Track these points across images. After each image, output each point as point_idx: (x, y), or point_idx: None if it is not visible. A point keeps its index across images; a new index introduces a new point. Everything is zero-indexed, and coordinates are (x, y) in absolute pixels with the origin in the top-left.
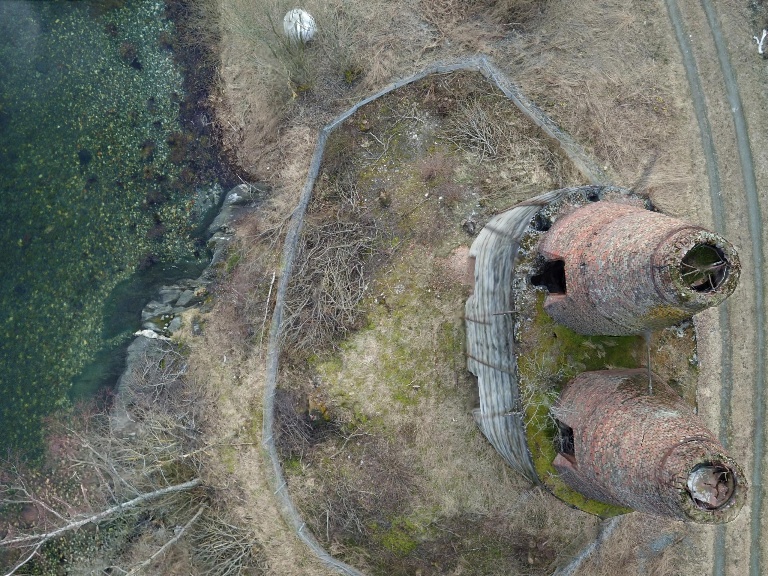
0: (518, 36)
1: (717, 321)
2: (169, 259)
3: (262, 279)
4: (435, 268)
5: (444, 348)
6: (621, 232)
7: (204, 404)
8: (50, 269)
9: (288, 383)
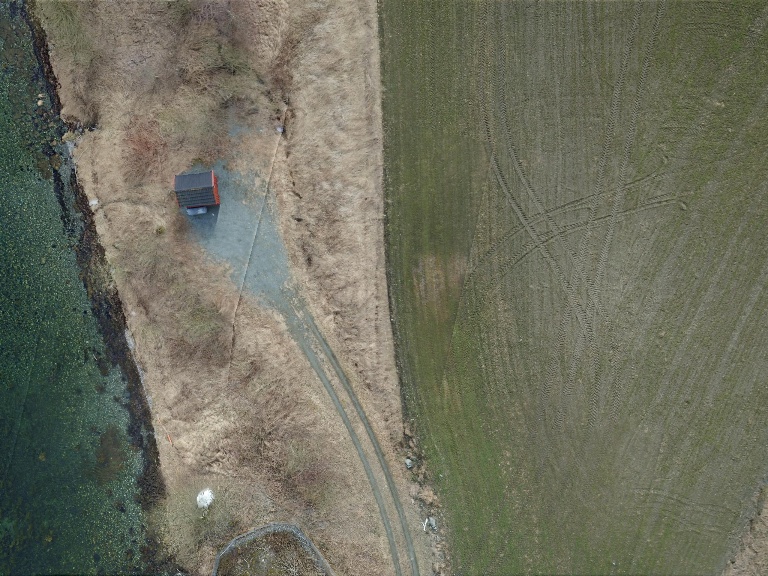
0: (313, 510)
1: None
2: None
3: None
4: None
5: None
6: None
7: None
8: None
9: None
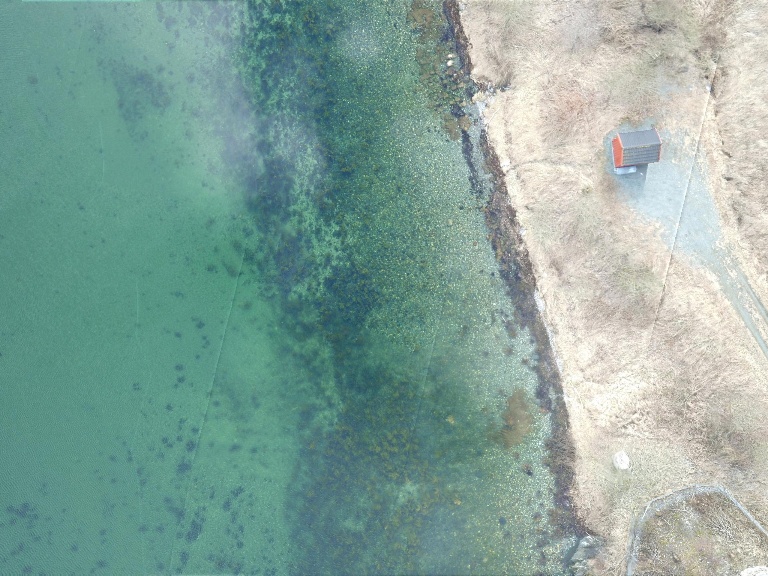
0: (739, 471)
1: None
2: (549, 574)
3: None
4: None
5: None
6: None
7: None
8: None
9: None
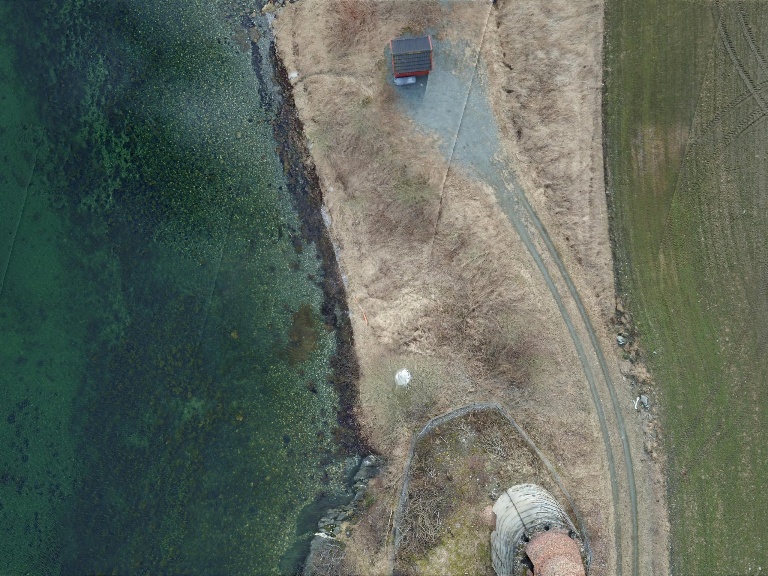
0: (516, 389)
1: (615, 543)
2: (332, 494)
3: (386, 513)
4: (476, 516)
5: (480, 555)
6: (552, 569)
7: (355, 575)
8: (268, 499)
9: (400, 567)
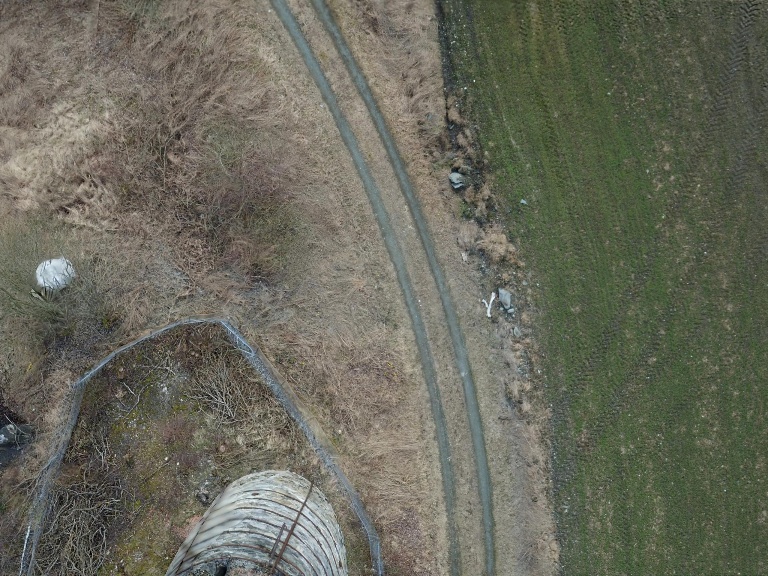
0: (264, 289)
1: None
2: None
3: (16, 534)
4: (171, 536)
5: None
6: None
7: None
8: None
9: None
